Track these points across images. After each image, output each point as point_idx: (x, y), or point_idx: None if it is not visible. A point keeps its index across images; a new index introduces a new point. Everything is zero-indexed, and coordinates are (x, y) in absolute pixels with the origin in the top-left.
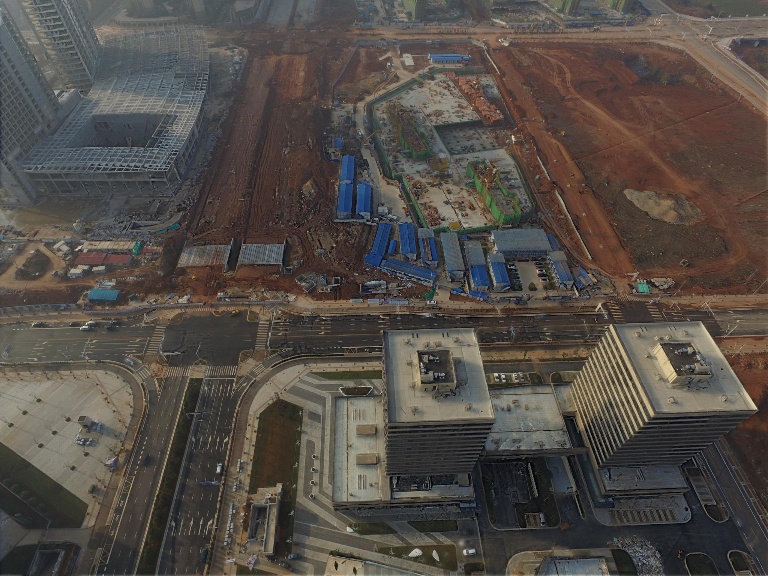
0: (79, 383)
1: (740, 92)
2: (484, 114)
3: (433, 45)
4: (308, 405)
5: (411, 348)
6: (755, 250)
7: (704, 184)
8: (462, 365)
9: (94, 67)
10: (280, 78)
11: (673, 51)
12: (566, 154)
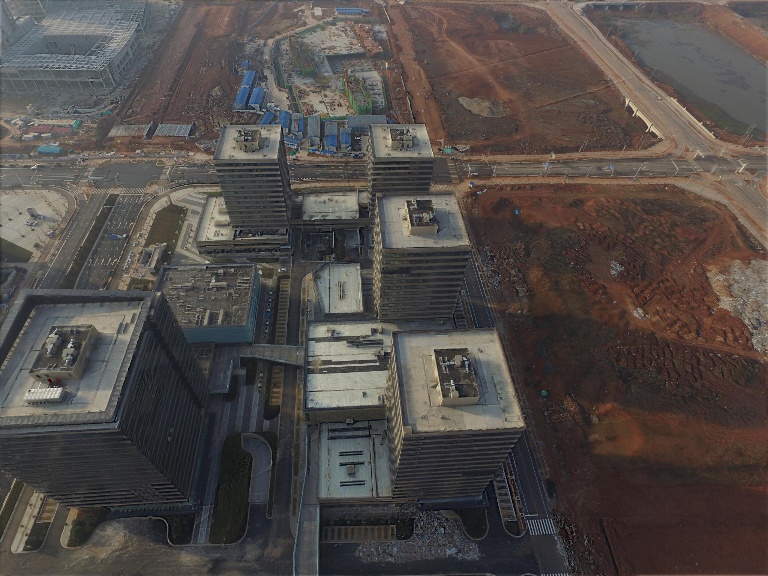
0: (29, 196)
1: (575, 39)
2: (368, 48)
3: (341, 2)
4: (192, 207)
5: None
6: (537, 131)
7: (520, 95)
8: (268, 140)
9: (47, 4)
10: (207, 22)
11: (536, 11)
12: (424, 75)
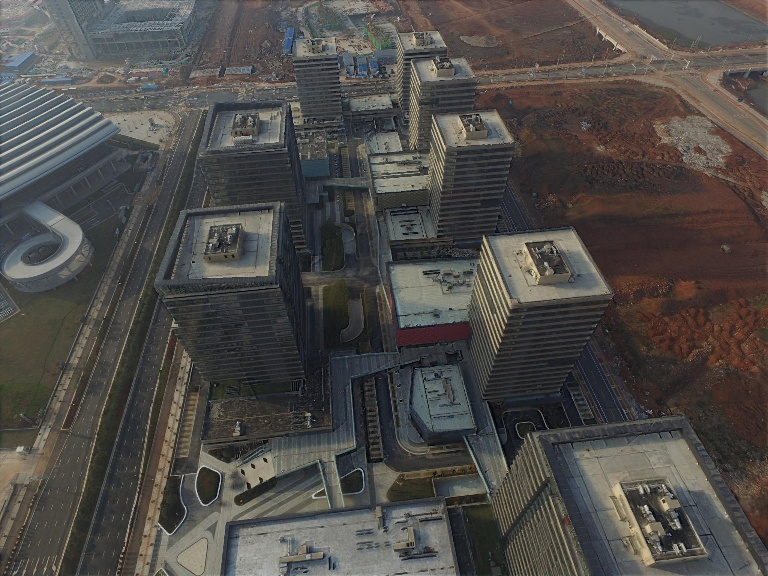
0: (144, 115)
1: None
2: (381, 8)
3: None
4: None
5: None
6: (524, 53)
7: (510, 31)
8: (327, 46)
9: None
10: None
11: None
12: (430, 23)
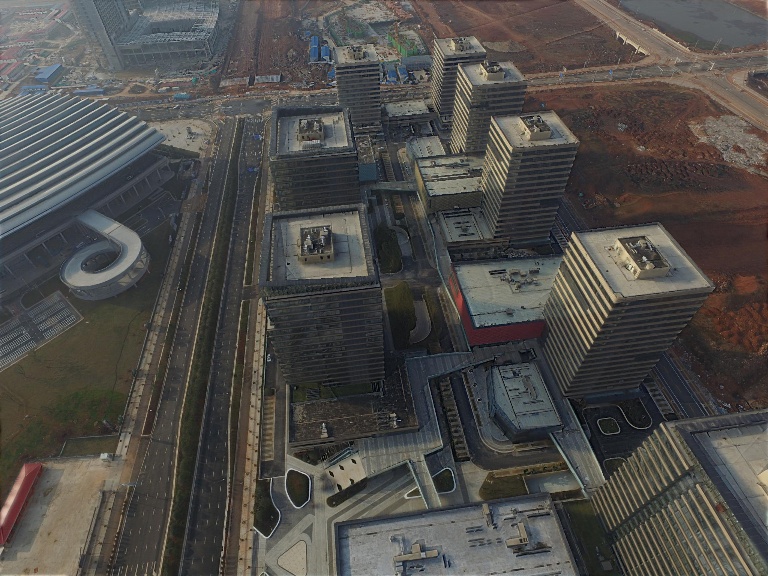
0: (180, 124)
1: None
2: (401, 16)
3: None
4: None
5: (345, 51)
6: (549, 58)
7: (531, 37)
8: (367, 53)
9: (141, 2)
10: (265, 9)
11: None
12: (451, 30)
